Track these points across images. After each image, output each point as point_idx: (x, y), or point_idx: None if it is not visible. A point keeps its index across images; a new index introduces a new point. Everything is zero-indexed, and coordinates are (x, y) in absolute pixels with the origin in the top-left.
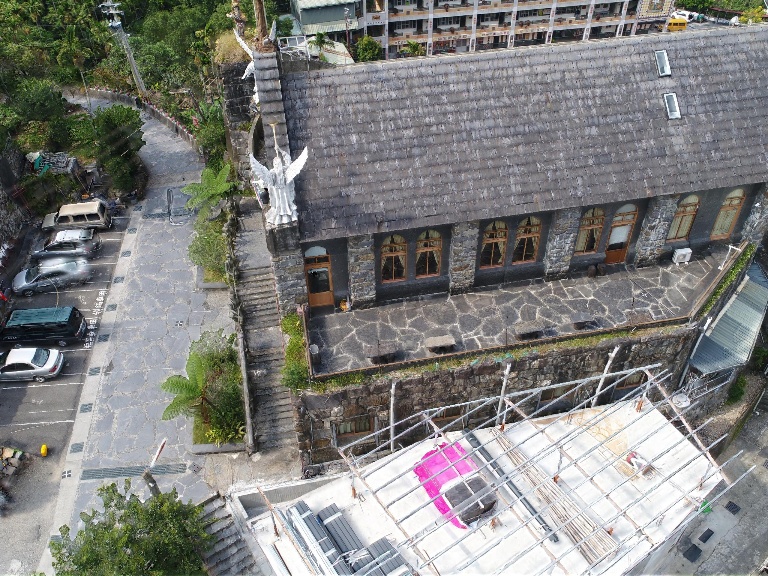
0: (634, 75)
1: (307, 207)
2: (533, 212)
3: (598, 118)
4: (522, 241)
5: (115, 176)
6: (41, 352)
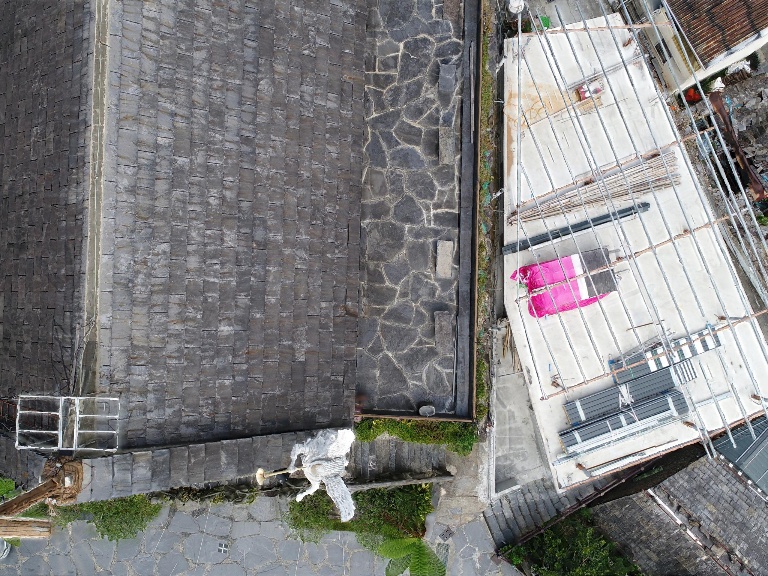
0: None
1: (312, 415)
2: None
3: None
4: None
5: None
6: None
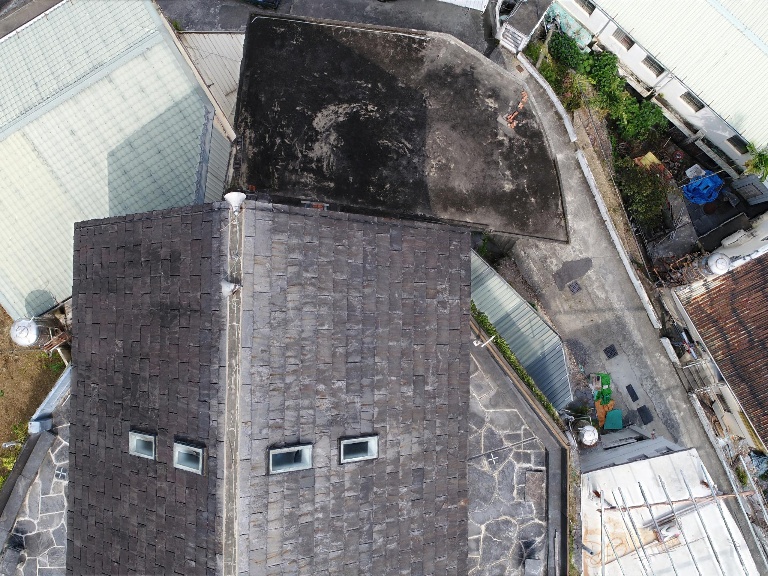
0: (302, 516)
1: None
2: None
3: None
4: None
5: None
6: None
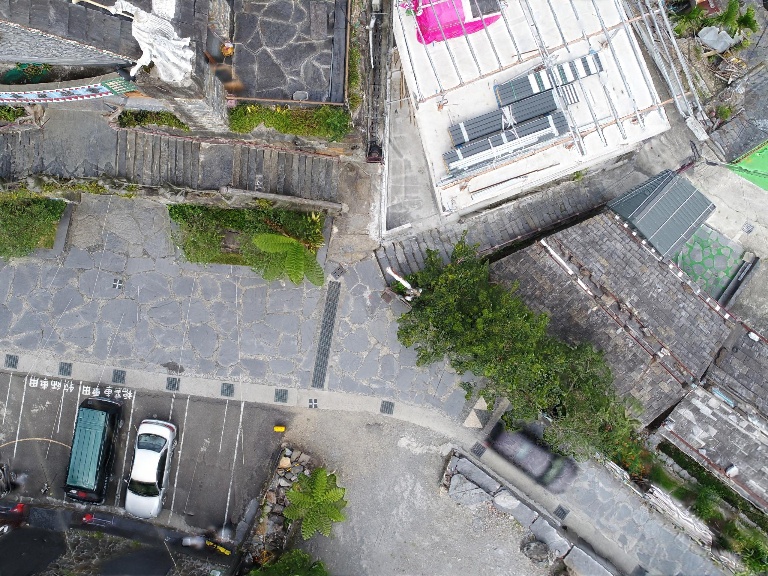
0: None
1: None
2: None
3: None
4: None
5: None
6: (144, 443)
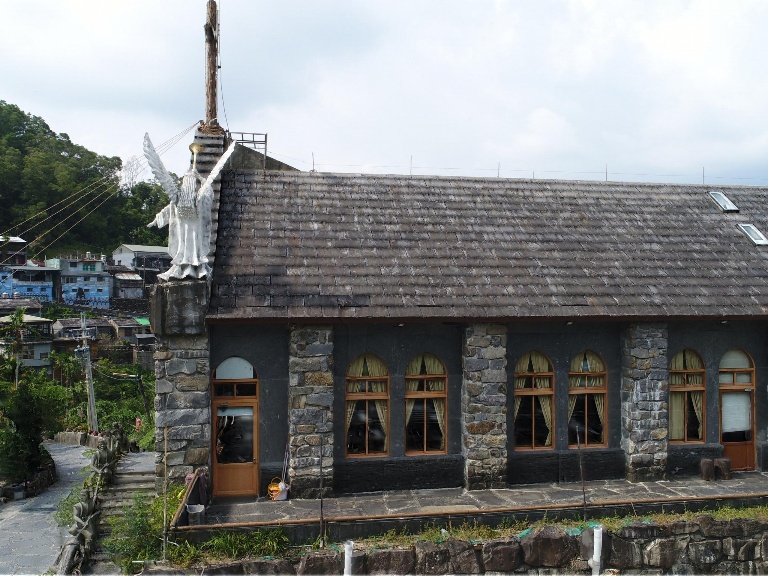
0: (690, 208)
1: (229, 281)
2: (590, 315)
3: (657, 237)
4: (579, 403)
5: (5, 455)
6: None
